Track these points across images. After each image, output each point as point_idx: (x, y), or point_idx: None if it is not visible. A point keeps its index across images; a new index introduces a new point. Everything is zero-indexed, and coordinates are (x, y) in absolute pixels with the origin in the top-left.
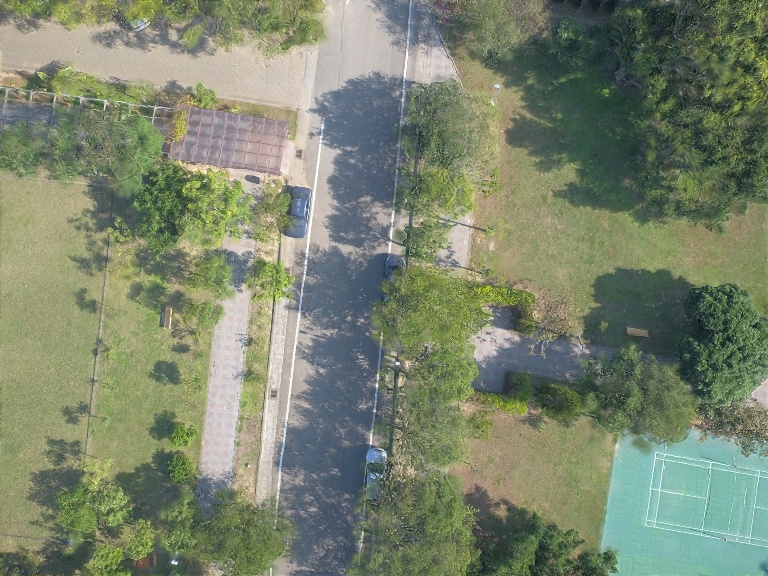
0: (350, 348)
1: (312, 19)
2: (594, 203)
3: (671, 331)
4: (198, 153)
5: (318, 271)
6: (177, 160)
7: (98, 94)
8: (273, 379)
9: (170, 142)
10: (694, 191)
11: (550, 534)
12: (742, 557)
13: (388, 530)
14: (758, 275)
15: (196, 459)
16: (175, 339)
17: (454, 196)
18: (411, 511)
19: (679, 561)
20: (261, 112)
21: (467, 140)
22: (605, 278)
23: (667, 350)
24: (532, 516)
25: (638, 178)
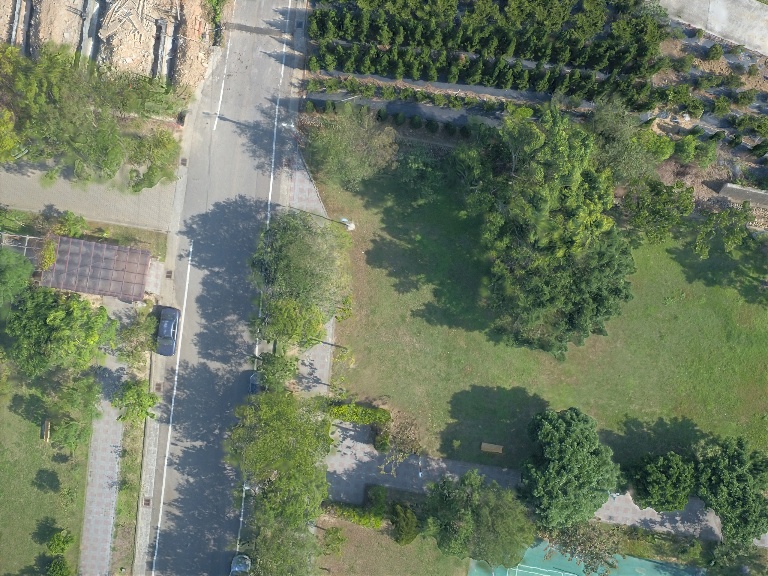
0: (218, 459)
1: (162, 163)
2: (451, 322)
3: (525, 446)
4: (67, 281)
5: (188, 387)
6: None
7: None
8: (146, 488)
9: (41, 270)
10: None
11: None
12: None
13: None
14: (612, 392)
15: (75, 562)
16: (55, 450)
17: (301, 328)
18: None
19: None
20: (133, 235)
21: (309, 278)
22: (461, 395)
23: (518, 466)
24: None
25: None
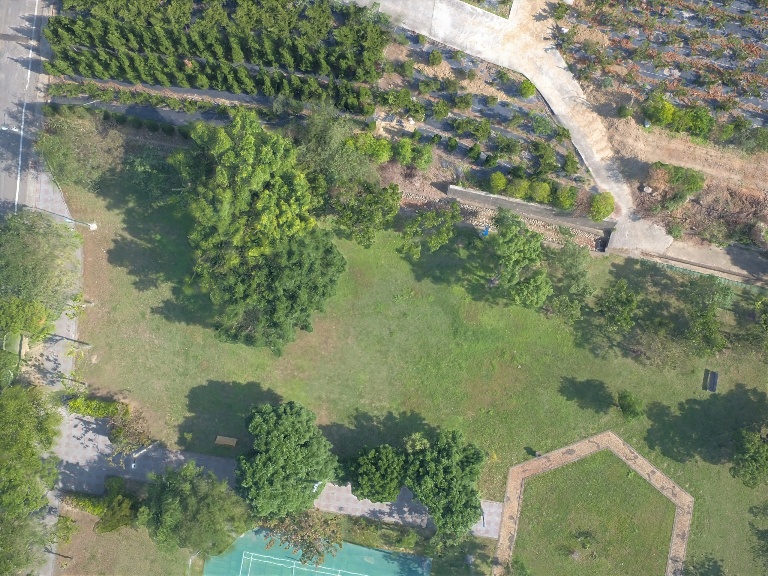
0: None
1: None
2: (189, 319)
3: None
4: None
5: None
6: None
7: None
8: None
9: None
10: None
11: None
12: None
13: None
14: (343, 387)
15: None
16: None
17: (22, 324)
18: None
19: None
20: None
21: (22, 276)
22: (199, 389)
23: None
24: None
25: None
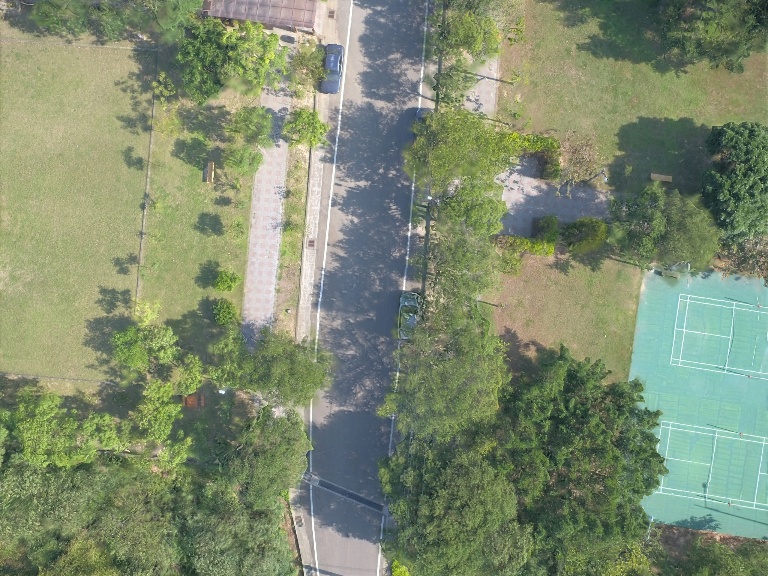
0: (383, 199)
1: None
2: (617, 54)
3: (694, 176)
4: (237, 10)
5: (351, 126)
6: (217, 18)
7: None
8: (310, 229)
9: None
10: (715, 31)
11: (578, 362)
12: (766, 393)
13: (423, 352)
14: None
15: (239, 306)
16: (217, 193)
17: (481, 38)
18: (444, 331)
19: (704, 397)
20: None
21: None
22: (629, 127)
23: (690, 193)
24: (560, 349)
25: (660, 29)
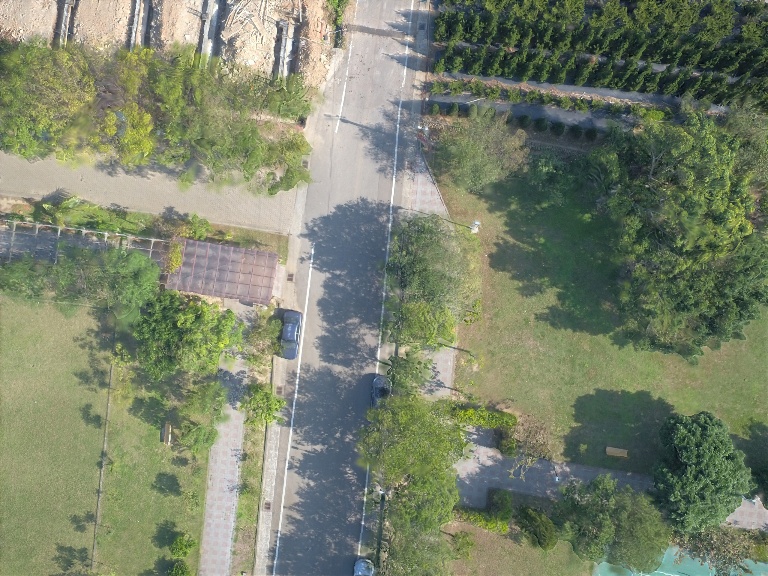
0: (339, 463)
1: (298, 165)
2: (575, 325)
3: (650, 450)
4: (193, 284)
5: (309, 390)
6: (174, 289)
7: (100, 222)
8: (266, 492)
9: (167, 273)
10: None
11: None
12: None
13: None
14: (737, 396)
15: (195, 566)
16: (174, 453)
17: (435, 332)
18: None
19: None
20: (254, 237)
21: (447, 282)
22: (585, 398)
23: (645, 470)
24: None
25: (619, 301)
